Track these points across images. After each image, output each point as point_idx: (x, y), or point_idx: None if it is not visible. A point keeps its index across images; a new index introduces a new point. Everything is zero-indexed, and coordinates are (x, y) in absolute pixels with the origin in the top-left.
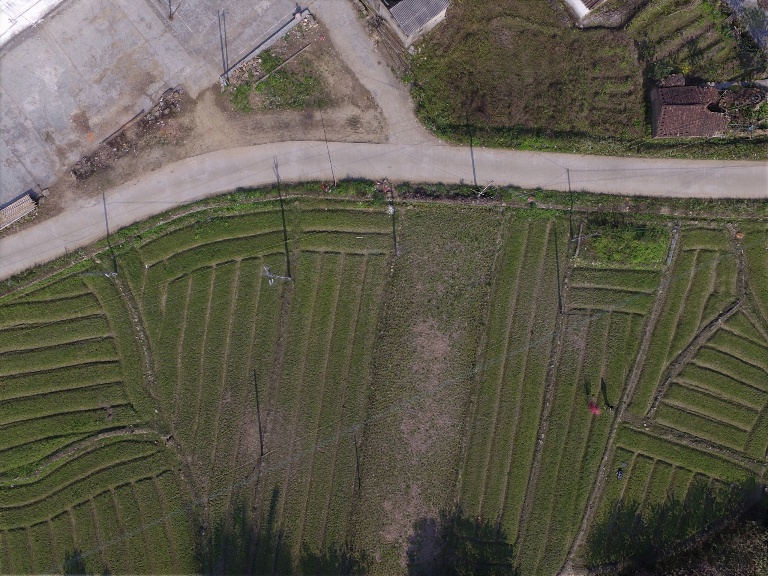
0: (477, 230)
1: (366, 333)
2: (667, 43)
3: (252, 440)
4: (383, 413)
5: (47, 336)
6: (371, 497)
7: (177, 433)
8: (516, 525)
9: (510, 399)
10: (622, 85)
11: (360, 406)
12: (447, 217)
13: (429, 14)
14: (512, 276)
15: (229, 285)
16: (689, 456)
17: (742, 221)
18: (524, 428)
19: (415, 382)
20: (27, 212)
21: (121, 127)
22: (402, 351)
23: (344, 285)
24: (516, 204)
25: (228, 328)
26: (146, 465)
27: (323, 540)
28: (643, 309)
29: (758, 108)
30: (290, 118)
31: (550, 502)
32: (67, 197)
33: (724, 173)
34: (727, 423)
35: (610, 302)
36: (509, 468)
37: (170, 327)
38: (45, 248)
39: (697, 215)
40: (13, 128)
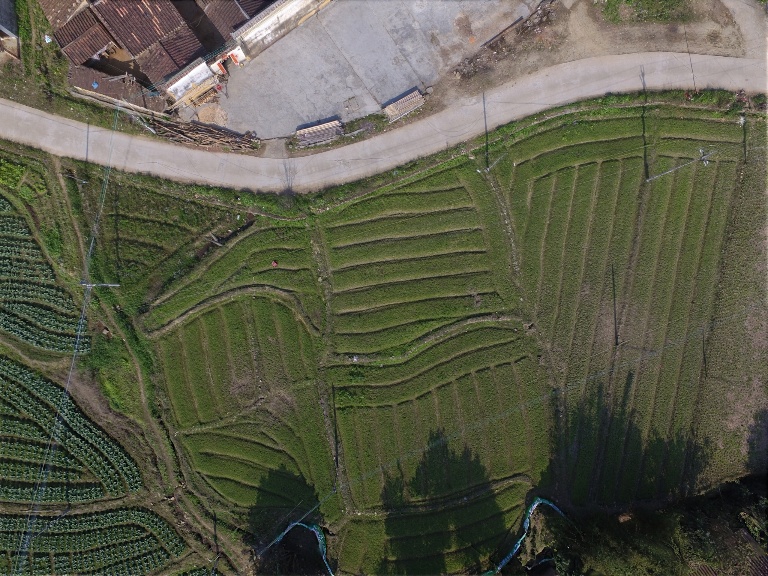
0: None
1: (716, 234)
2: None
3: (608, 330)
4: (729, 310)
5: (423, 225)
6: (716, 388)
7: (539, 321)
8: None
9: None
10: None
11: (708, 302)
12: None
13: None
14: None
15: (591, 185)
16: None
17: None
18: None
19: (759, 282)
20: (417, 106)
21: (501, 32)
22: (748, 253)
23: (697, 189)
24: None
25: (588, 225)
26: (507, 351)
27: (670, 426)
28: None
29: None
30: (656, 30)
31: None
32: (450, 95)
33: None
34: None
35: None
36: None
37: (536, 221)
38: (428, 142)
39: None
40: (402, 29)
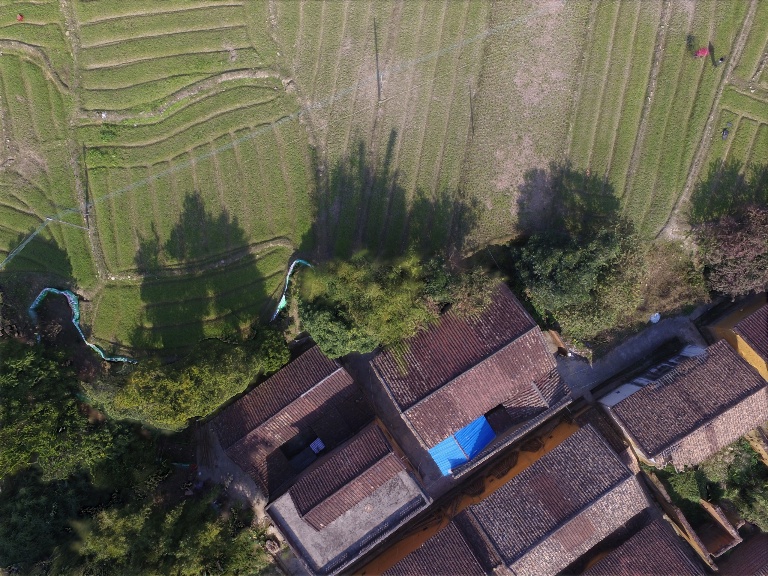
0: None
1: None
2: None
3: (370, 87)
4: (498, 66)
5: None
6: (484, 146)
7: (298, 77)
8: (623, 179)
9: (621, 57)
10: None
11: (476, 58)
12: None
13: None
14: None
15: None
16: None
17: None
18: (634, 85)
19: (529, 37)
20: None
21: None
22: (517, 7)
23: None
24: None
25: None
26: (266, 110)
27: (436, 186)
28: None
29: None
30: None
31: (657, 158)
32: None
33: None
34: None
35: None
36: (618, 125)
37: None
38: None
39: None
40: None
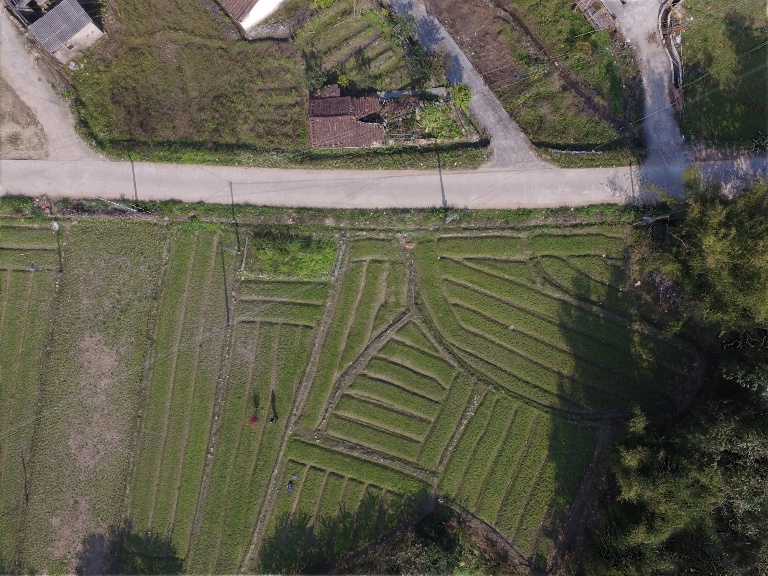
0: (143, 244)
1: (32, 349)
2: (333, 53)
3: None
4: (50, 429)
5: None
6: (39, 513)
7: None
8: (186, 539)
9: (178, 413)
10: (286, 97)
11: (27, 422)
12: (113, 232)
13: (70, 30)
14: (179, 290)
15: None
16: (360, 468)
17: (412, 231)
18: (193, 442)
19: (82, 398)
20: None
21: None
22: (69, 367)
23: (9, 302)
24: (178, 218)
25: None
26: None
27: None
28: (311, 321)
29: (419, 117)
30: None
31: (219, 516)
32: None
33: (390, 183)
34: (400, 434)
35: (278, 314)
36: (179, 482)
37: None
38: None
39: (364, 226)
40: None
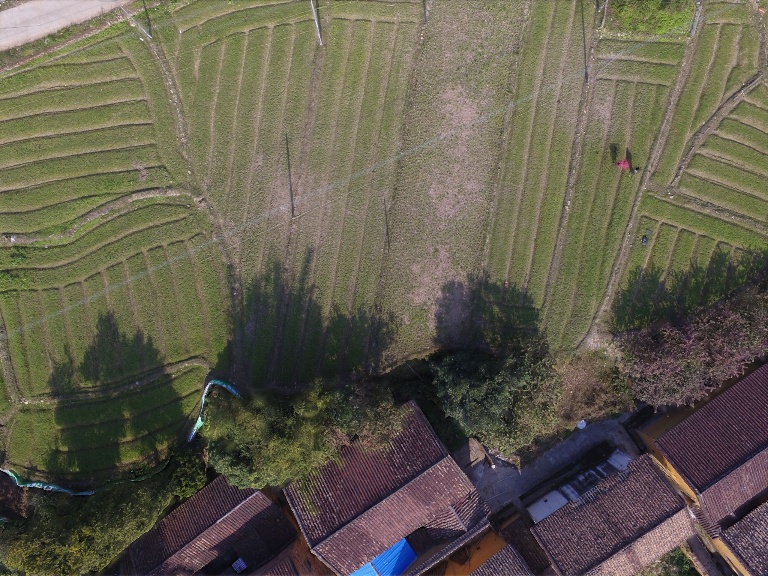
0: (505, 0)
1: (396, 99)
2: None
3: (283, 203)
4: (412, 178)
5: (82, 97)
6: (400, 260)
7: (210, 195)
8: (542, 290)
9: (537, 166)
10: None
11: (390, 171)
12: None
13: None
14: (539, 46)
15: (262, 50)
16: (712, 224)
17: None
18: (551, 194)
19: (444, 148)
20: None
21: None
22: (431, 118)
23: (375, 52)
24: None
25: (260, 93)
26: (179, 228)
27: (353, 302)
28: (668, 80)
29: None
30: None
31: (576, 267)
32: None
33: None
34: (749, 193)
35: (635, 73)
36: (536, 234)
37: (203, 90)
38: (81, 8)
39: None
40: None
